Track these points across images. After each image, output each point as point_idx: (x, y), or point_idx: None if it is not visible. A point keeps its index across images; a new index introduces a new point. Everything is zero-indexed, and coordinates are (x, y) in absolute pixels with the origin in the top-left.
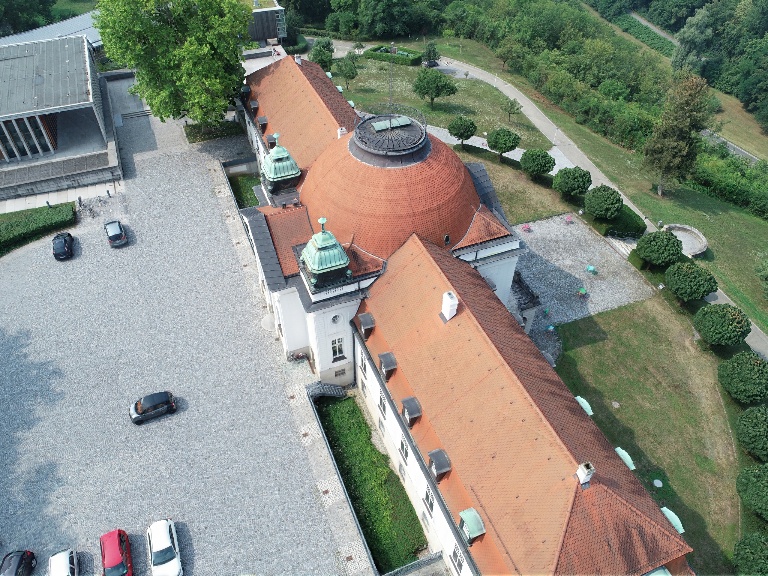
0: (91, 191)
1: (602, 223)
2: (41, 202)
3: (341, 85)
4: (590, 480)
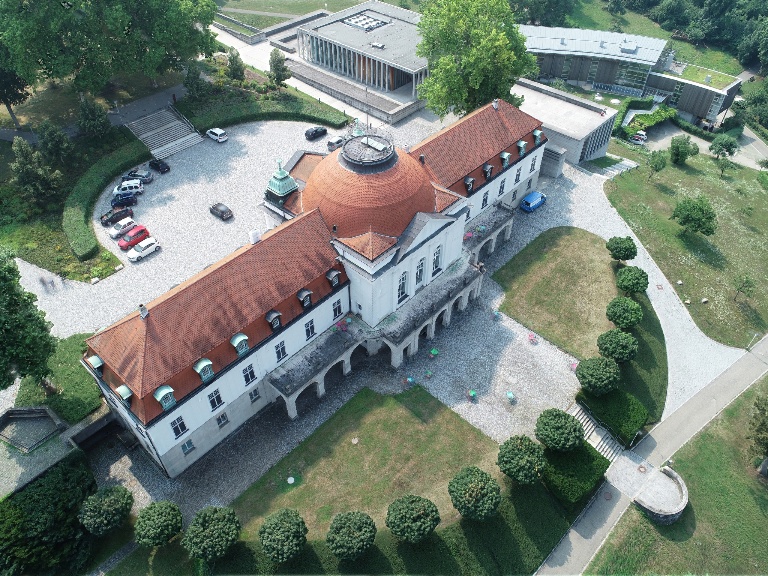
0: (370, 120)
1: None
2: (347, 110)
3: (660, 175)
4: (145, 319)
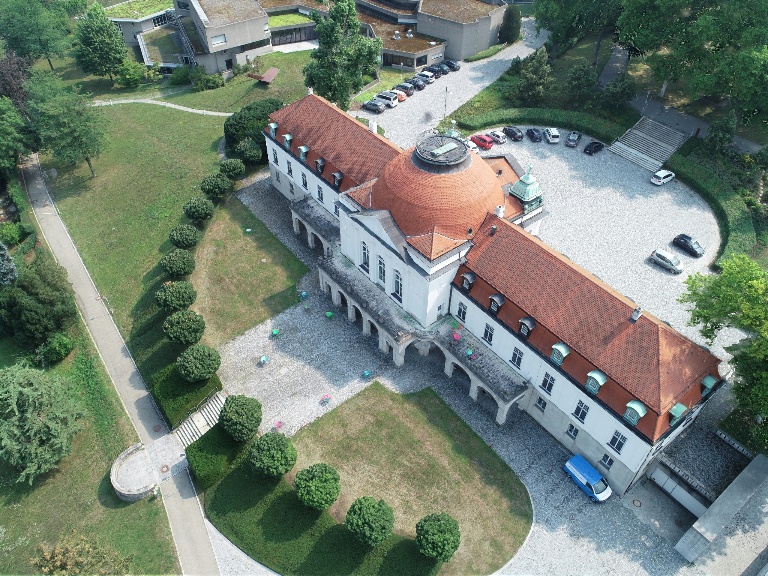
0: None
1: None
2: None
3: None
4: None
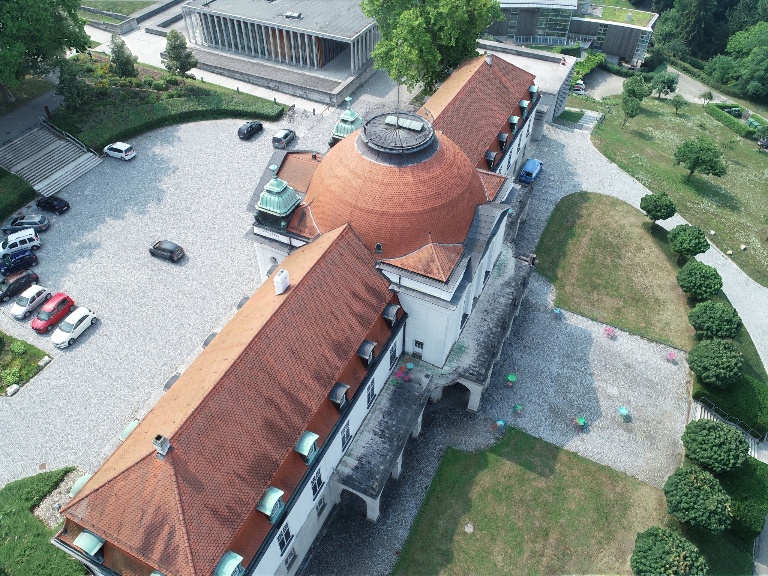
0: (309, 105)
1: (699, 382)
2: (276, 98)
3: (627, 121)
4: (167, 456)
